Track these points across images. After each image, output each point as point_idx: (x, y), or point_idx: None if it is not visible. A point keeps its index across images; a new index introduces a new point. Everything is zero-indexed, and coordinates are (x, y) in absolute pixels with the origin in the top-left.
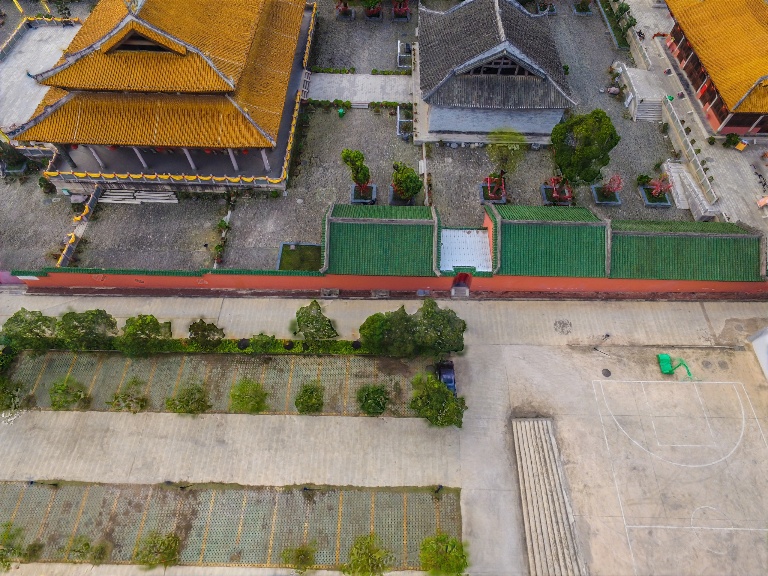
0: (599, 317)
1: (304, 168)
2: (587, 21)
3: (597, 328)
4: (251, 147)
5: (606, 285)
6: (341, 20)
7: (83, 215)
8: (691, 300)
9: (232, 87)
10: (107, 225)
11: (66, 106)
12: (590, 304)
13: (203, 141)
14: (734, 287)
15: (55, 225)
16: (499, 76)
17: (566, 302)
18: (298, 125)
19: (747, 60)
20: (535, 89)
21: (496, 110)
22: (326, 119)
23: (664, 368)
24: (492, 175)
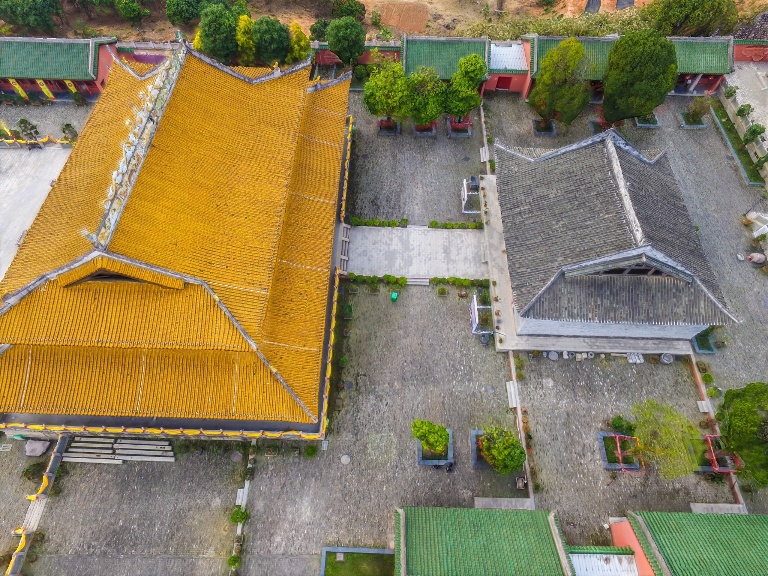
0: None
1: (349, 396)
2: (700, 138)
3: None
4: (280, 420)
5: None
6: (383, 135)
7: (39, 494)
8: None
9: (253, 348)
10: (74, 504)
11: (10, 353)
12: None
13: (210, 409)
14: None
15: (2, 497)
16: (625, 276)
17: None
18: (337, 317)
19: None
20: (677, 295)
21: None
22: (374, 305)
23: None
24: (616, 421)
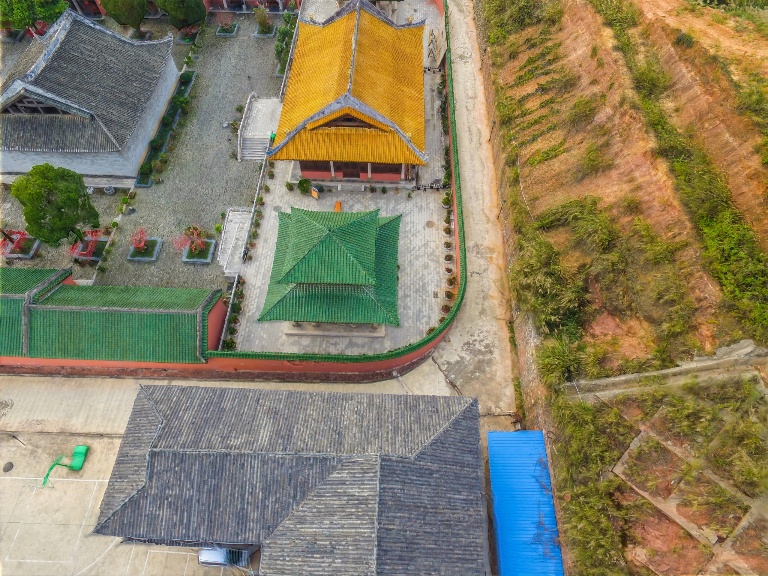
0: (48, 397)
1: None
2: (264, 44)
3: (37, 411)
4: None
5: (53, 362)
6: (4, 42)
7: None
8: (158, 378)
9: None
10: None
11: None
12: (49, 381)
13: None
14: (182, 367)
15: None
16: (44, 115)
17: (25, 378)
18: None
19: (313, 99)
20: (82, 130)
21: (46, 152)
22: None
23: (72, 463)
24: None
